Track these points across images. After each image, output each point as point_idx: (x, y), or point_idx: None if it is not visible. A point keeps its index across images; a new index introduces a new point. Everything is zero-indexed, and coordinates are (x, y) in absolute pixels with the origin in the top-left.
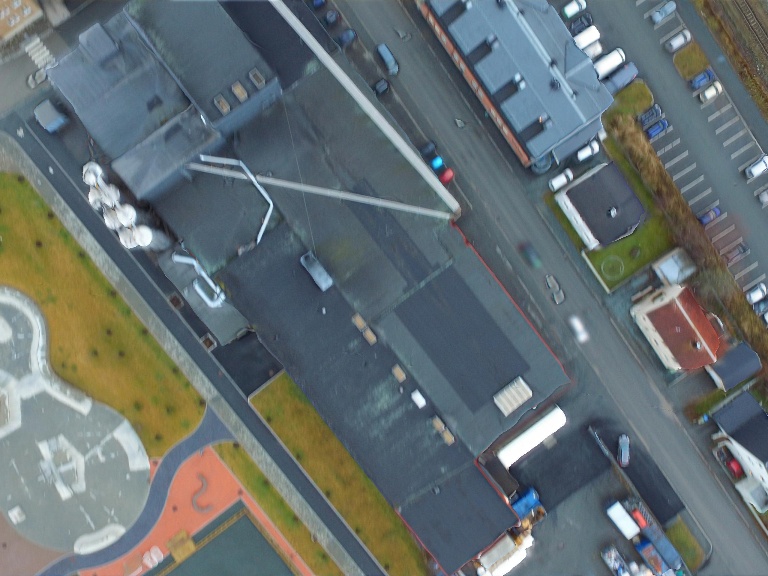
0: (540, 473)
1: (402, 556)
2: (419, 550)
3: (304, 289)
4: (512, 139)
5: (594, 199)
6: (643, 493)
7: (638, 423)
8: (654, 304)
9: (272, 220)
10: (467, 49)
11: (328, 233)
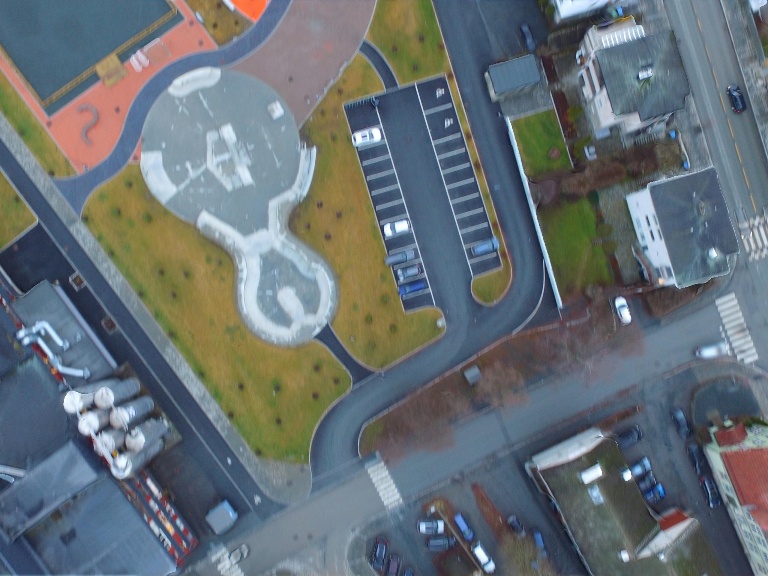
0: None
1: None
2: None
3: None
4: None
5: None
6: None
7: None
8: None
9: None
10: None
11: None
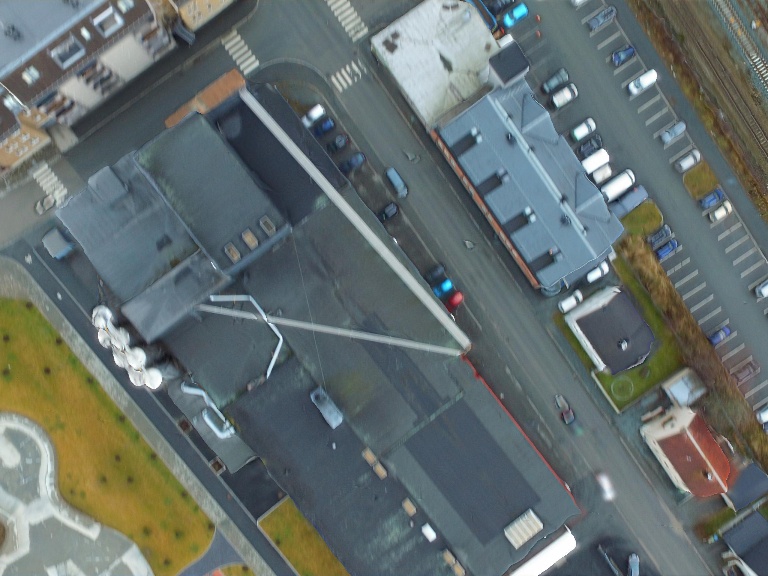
0: None
1: None
2: None
3: (314, 424)
4: (522, 263)
5: (604, 330)
6: None
7: (648, 542)
8: (664, 430)
9: (282, 354)
10: (477, 180)
11: (338, 368)
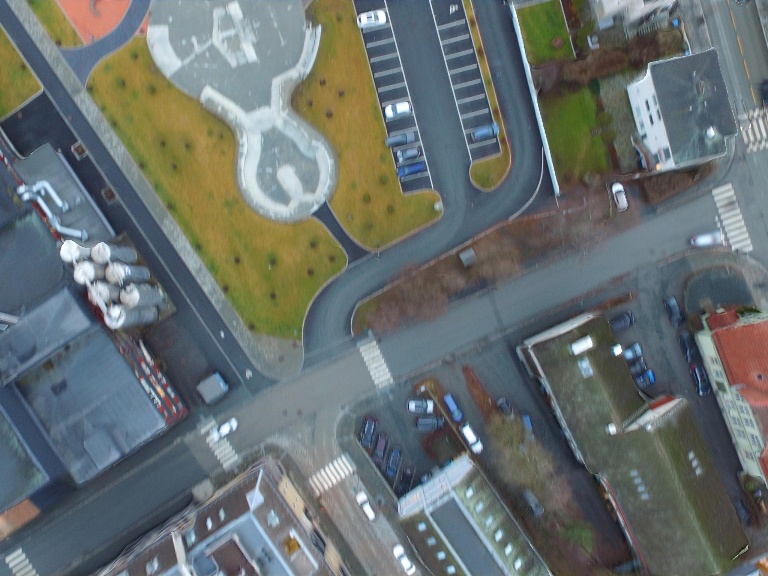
0: None
1: None
2: None
3: None
4: None
5: None
6: None
7: None
8: None
9: None
10: None
11: None
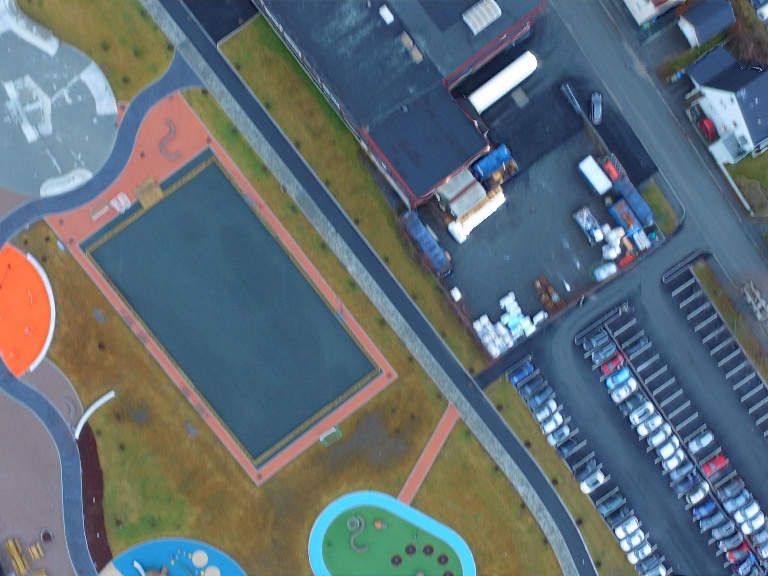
0: (512, 133)
1: (372, 212)
2: (390, 208)
3: None
4: None
5: None
6: (616, 154)
7: (611, 82)
8: None
9: None
10: None
11: None
